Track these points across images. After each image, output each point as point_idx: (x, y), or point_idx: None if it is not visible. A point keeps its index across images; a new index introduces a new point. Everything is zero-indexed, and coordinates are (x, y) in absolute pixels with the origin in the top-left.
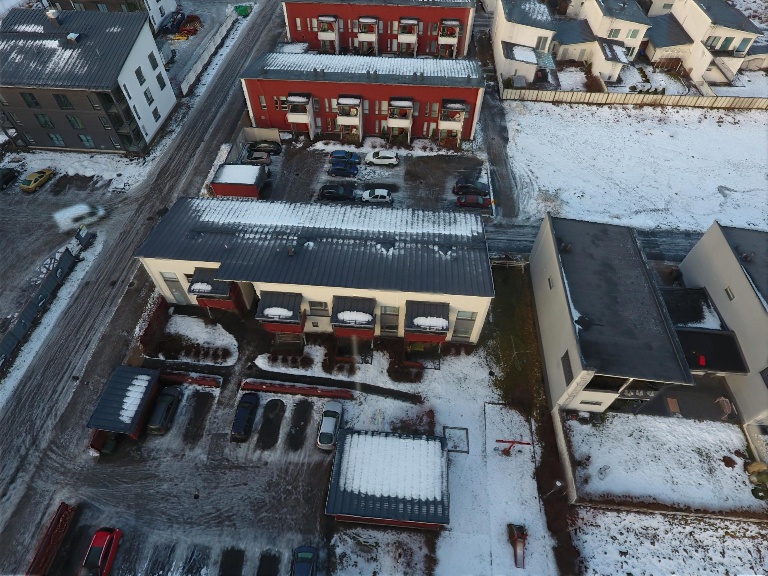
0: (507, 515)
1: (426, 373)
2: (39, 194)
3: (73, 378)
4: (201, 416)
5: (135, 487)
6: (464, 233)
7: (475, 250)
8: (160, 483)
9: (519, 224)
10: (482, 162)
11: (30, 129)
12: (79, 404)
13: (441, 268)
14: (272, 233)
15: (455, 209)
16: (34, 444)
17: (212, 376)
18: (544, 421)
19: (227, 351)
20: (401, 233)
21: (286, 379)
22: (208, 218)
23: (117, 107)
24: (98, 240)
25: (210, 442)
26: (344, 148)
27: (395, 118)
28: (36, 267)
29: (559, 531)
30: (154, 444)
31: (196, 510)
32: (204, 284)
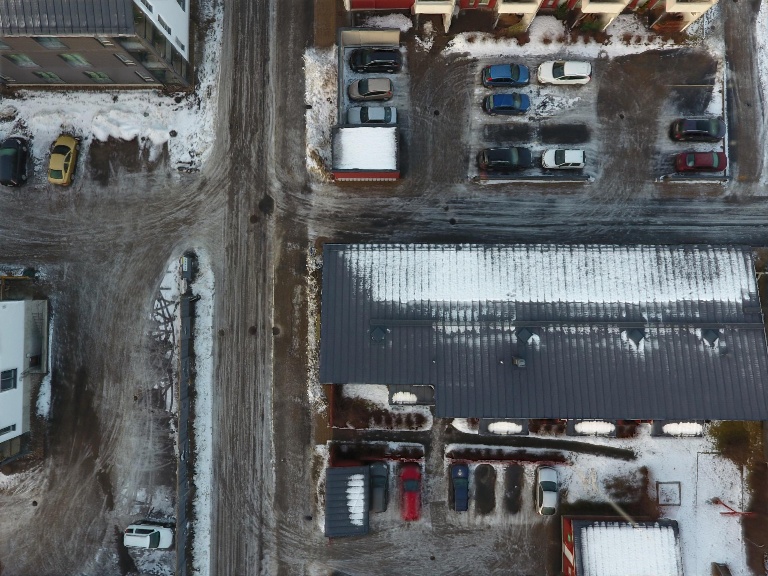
0: (712, 556)
1: (639, 427)
2: (80, 186)
3: (306, 519)
4: (413, 486)
5: (375, 556)
6: (732, 298)
7: (749, 332)
8: (396, 551)
9: (760, 194)
10: (716, 64)
11: (1, 68)
12: (287, 483)
13: (709, 373)
14: (480, 321)
15: (677, 178)
16: (262, 524)
17: (412, 445)
18: (757, 469)
19: (420, 416)
20: (649, 305)
21: (490, 442)
22: (383, 295)
23: (144, 43)
24: (202, 263)
25: (430, 511)
26: (500, 47)
27: (601, 2)
28: (148, 315)
29: (757, 567)
30: (378, 517)
31: (436, 570)
32: (407, 394)
